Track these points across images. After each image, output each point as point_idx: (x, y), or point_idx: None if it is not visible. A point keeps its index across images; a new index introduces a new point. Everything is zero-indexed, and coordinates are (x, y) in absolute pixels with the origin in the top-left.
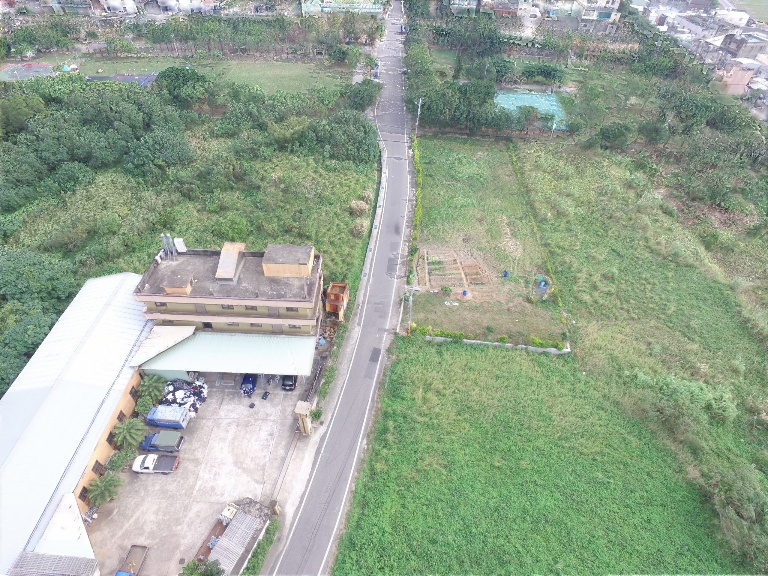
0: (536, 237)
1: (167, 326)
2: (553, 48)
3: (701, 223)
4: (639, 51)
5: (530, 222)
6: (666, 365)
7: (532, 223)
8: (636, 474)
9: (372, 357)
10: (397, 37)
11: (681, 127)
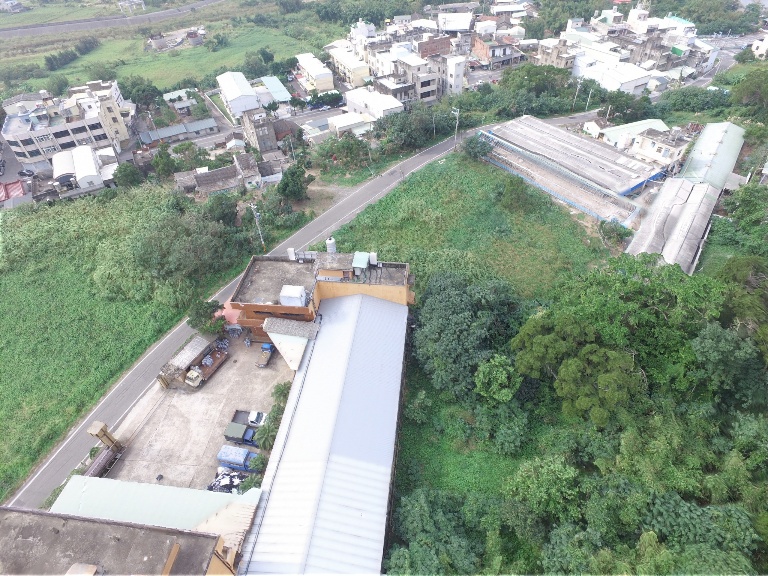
0: None
1: None
2: None
3: None
4: None
5: None
6: None
7: None
8: None
9: None
10: None
11: None
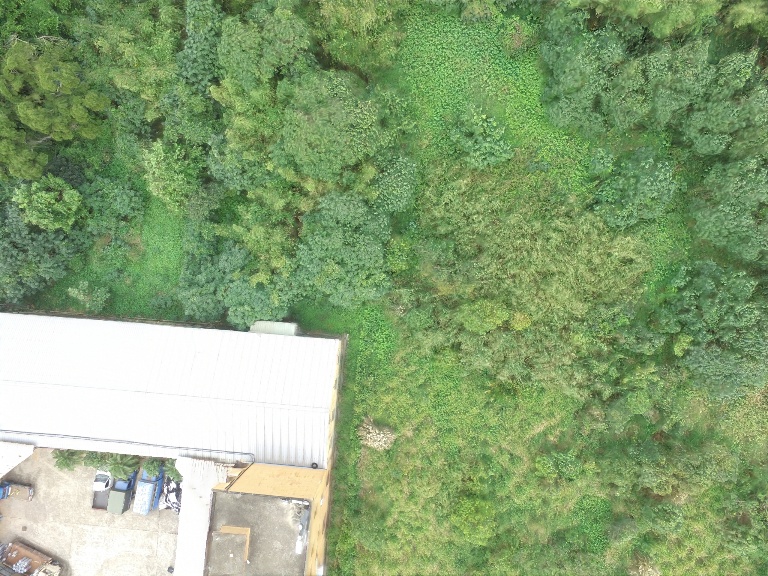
0: None
1: None
2: None
3: None
4: None
5: None
6: None
7: None
8: None
9: None
10: None
11: None
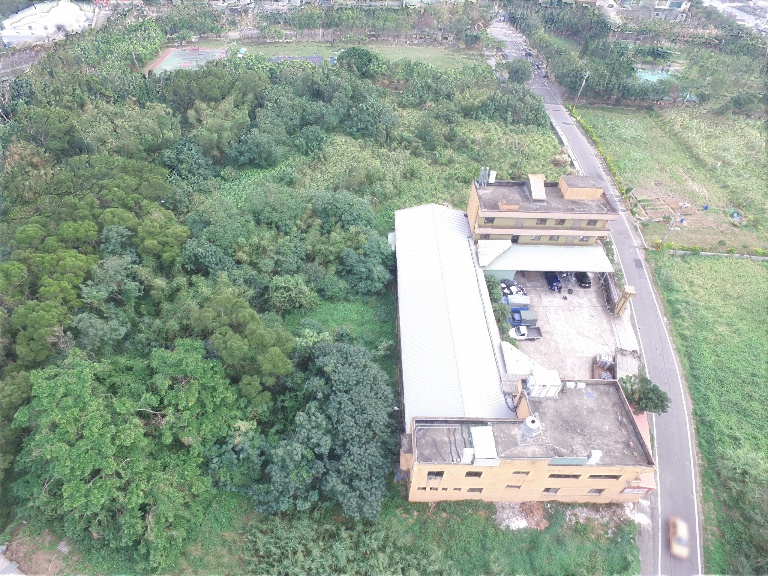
0: (712, 182)
1: (488, 240)
2: (649, 33)
3: None
4: (715, 36)
5: (701, 171)
6: None
7: (703, 172)
8: None
9: (637, 265)
10: (499, 24)
11: None
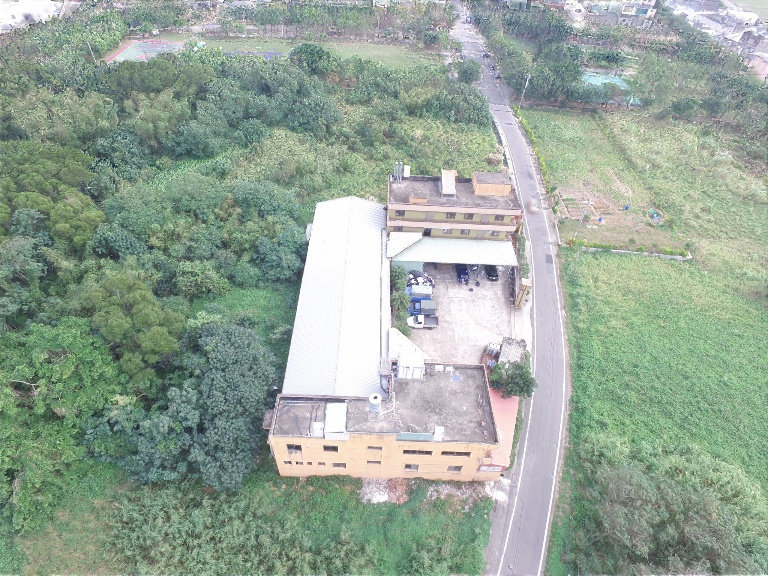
0: (640, 183)
1: (400, 232)
2: (608, 38)
3: (763, 176)
4: (676, 43)
5: (631, 172)
6: (764, 267)
7: (633, 173)
8: (760, 331)
9: (547, 260)
10: (465, 26)
11: (732, 104)
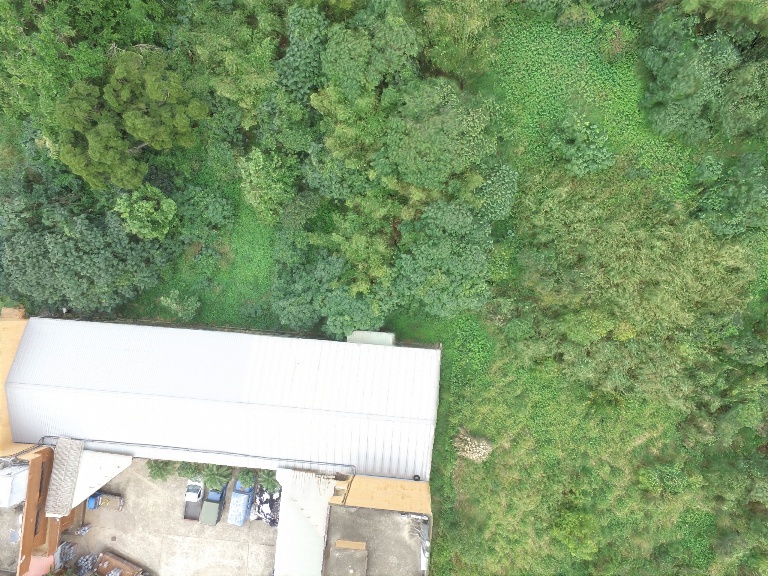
0: None
1: None
2: None
3: None
4: None
5: None
6: None
7: None
8: None
9: None
10: None
11: None
